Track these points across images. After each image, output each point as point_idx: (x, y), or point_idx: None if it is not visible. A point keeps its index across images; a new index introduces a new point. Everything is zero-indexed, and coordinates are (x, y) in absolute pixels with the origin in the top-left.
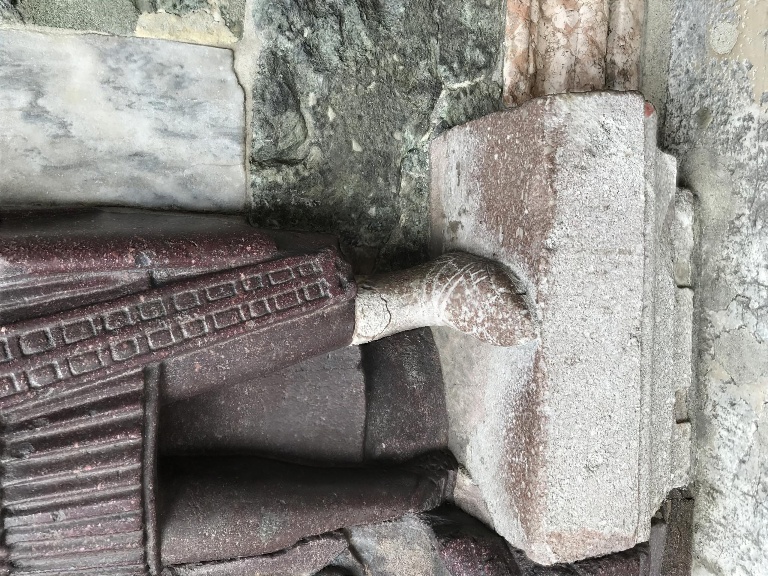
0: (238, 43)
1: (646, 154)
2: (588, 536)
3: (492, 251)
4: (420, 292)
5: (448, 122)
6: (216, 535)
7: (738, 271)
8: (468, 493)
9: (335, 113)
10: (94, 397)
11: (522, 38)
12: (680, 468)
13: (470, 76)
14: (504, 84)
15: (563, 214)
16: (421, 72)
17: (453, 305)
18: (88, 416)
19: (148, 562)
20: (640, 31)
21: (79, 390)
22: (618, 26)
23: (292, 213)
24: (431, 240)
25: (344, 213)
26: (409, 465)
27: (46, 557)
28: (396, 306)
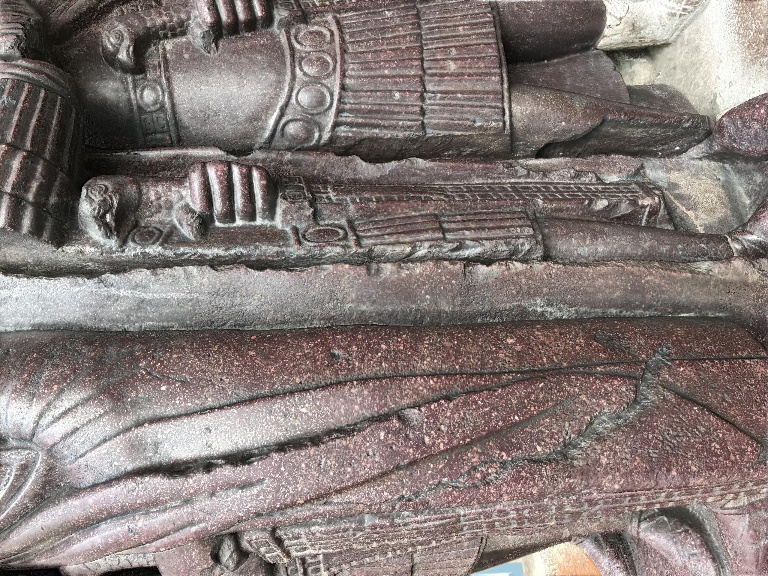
0: None
1: None
2: None
3: None
4: None
5: None
6: (545, 98)
7: None
8: None
9: None
10: (463, 5)
11: None
12: None
13: None
14: None
15: None
16: None
17: None
18: (463, 8)
19: (504, 105)
20: None
21: (455, 2)
22: None
23: None
24: None
25: None
26: None
27: (444, 84)
28: (630, 2)
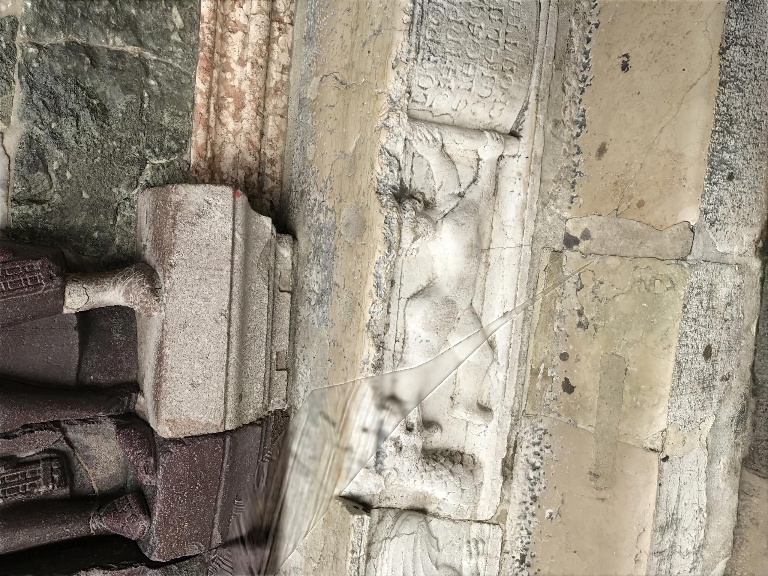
0: (7, 129)
1: (237, 217)
2: (192, 423)
3: (154, 264)
4: (109, 285)
5: (151, 183)
6: None
7: (309, 284)
8: (142, 406)
9: (71, 174)
10: None
11: (201, 137)
12: (278, 397)
13: (167, 157)
14: (191, 163)
15: (180, 247)
16: (133, 153)
17: (126, 293)
18: None
19: None
20: (283, 137)
21: None
22: (267, 133)
23: (39, 233)
24: (136, 254)
25: (75, 235)
26: (107, 389)
27: None
28: (92, 292)
